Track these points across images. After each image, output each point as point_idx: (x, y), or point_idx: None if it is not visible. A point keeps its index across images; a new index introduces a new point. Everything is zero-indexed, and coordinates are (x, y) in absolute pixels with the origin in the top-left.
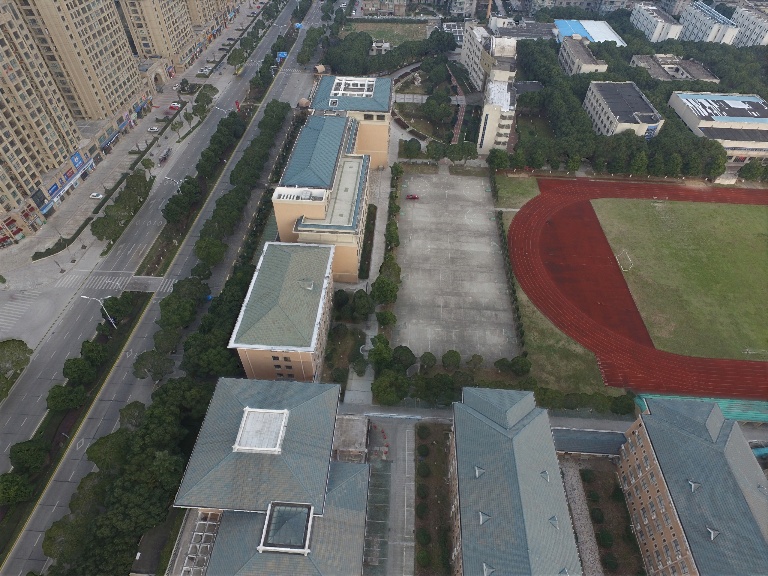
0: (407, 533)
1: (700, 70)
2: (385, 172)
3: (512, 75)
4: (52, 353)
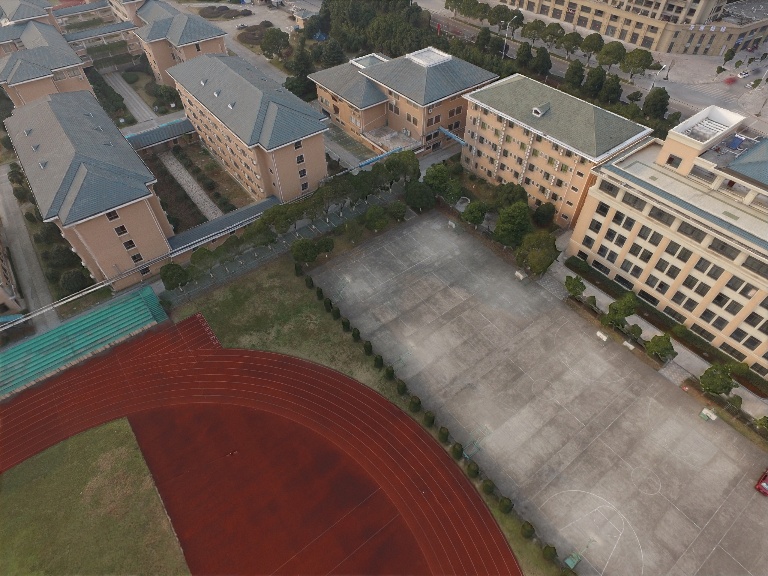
0: None
1: None
2: None
3: None
4: None
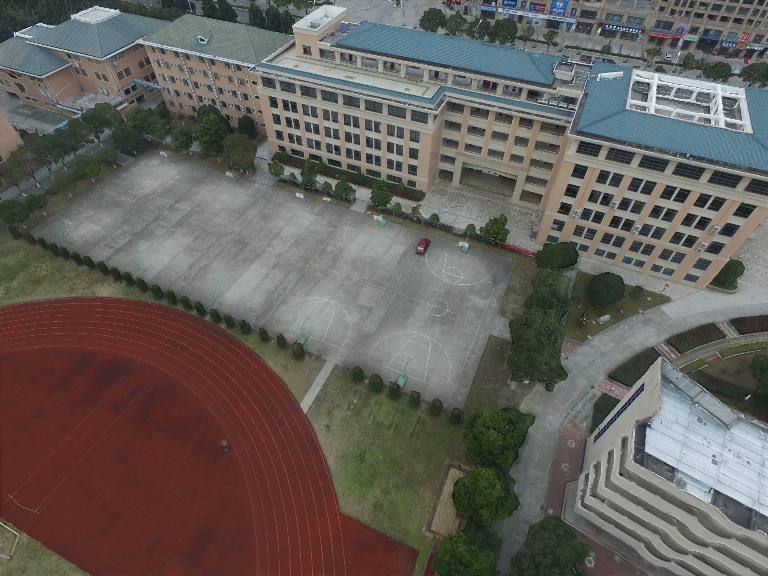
0: (13, 124)
1: None
2: (523, 237)
3: None
4: None
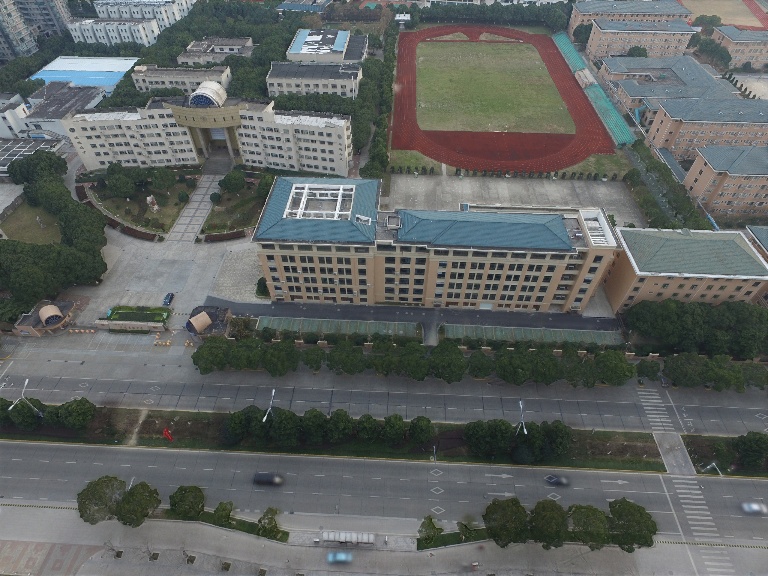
0: None
1: (227, 40)
2: None
3: (273, 105)
4: None
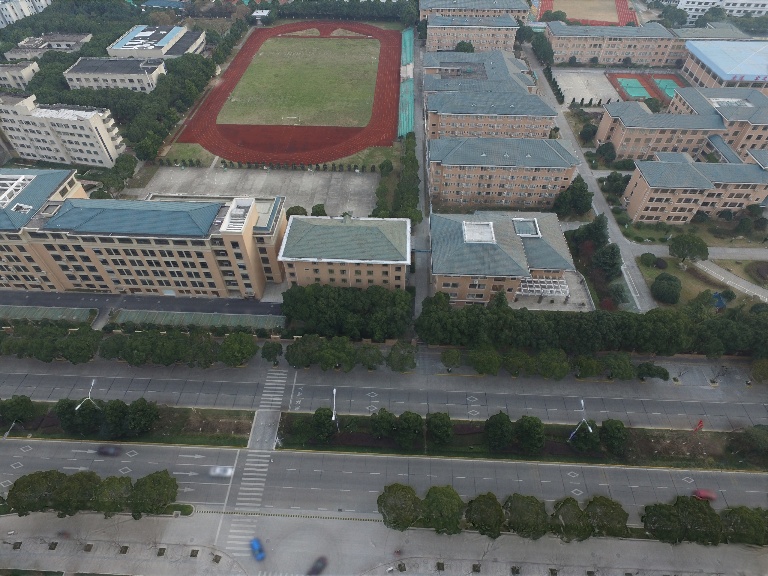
0: None
1: (66, 36)
2: None
3: (34, 99)
4: (372, 494)
